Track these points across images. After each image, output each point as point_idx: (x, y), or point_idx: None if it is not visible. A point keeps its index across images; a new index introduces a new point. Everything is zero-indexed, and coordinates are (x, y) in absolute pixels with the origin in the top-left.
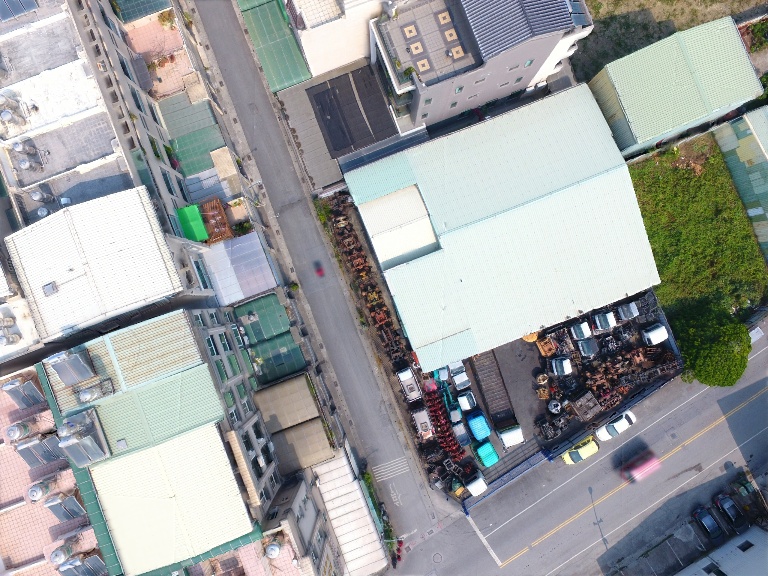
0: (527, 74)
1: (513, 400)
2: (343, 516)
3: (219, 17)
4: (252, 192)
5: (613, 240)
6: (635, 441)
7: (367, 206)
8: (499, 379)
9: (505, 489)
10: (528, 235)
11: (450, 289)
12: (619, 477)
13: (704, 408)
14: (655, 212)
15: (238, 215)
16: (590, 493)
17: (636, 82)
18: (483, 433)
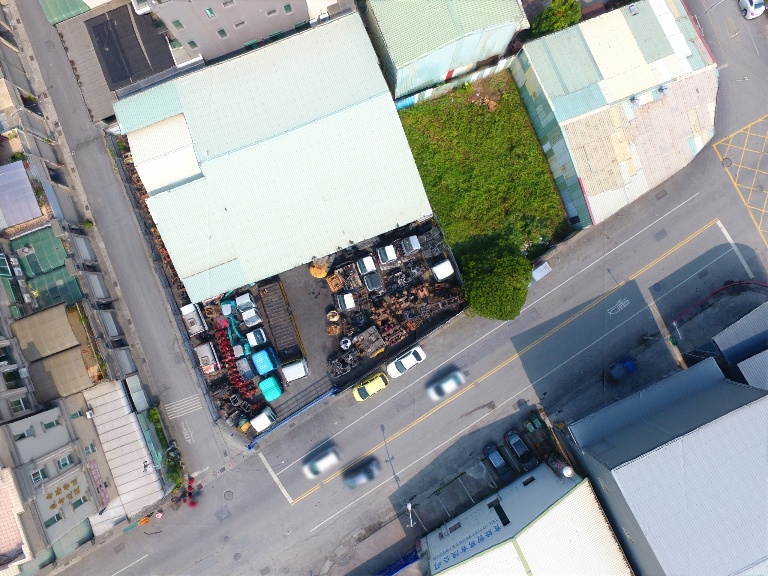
0: (292, 1)
1: (306, 338)
2: (118, 448)
3: None
4: (47, 130)
5: (381, 169)
6: (428, 379)
7: (136, 136)
8: (287, 315)
9: (298, 427)
10: (294, 164)
11: (215, 218)
12: (411, 415)
13: (497, 345)
14: (449, 149)
15: (16, 148)
16: (382, 430)
17: (393, 6)
18: (265, 367)
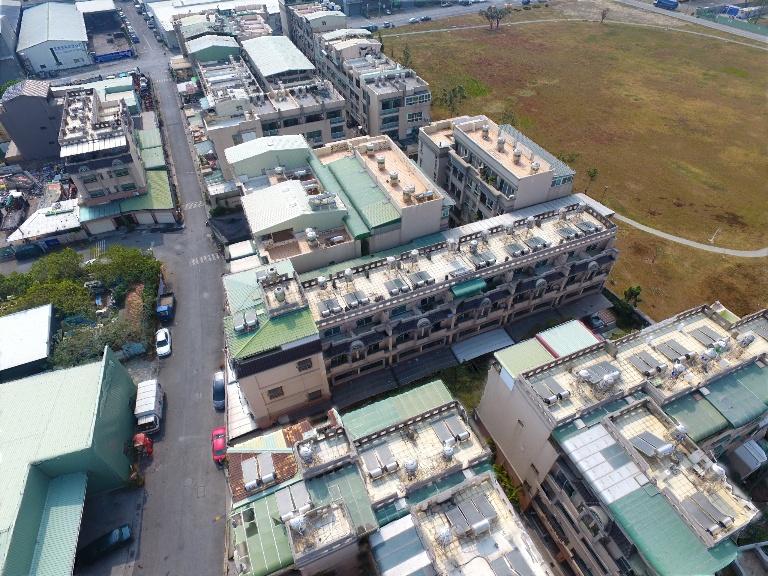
0: None
1: None
2: None
3: None
4: None
5: None
6: None
7: None
8: None
9: None
10: None
11: None
12: None
13: None
14: None
15: None
16: None
17: None
18: None
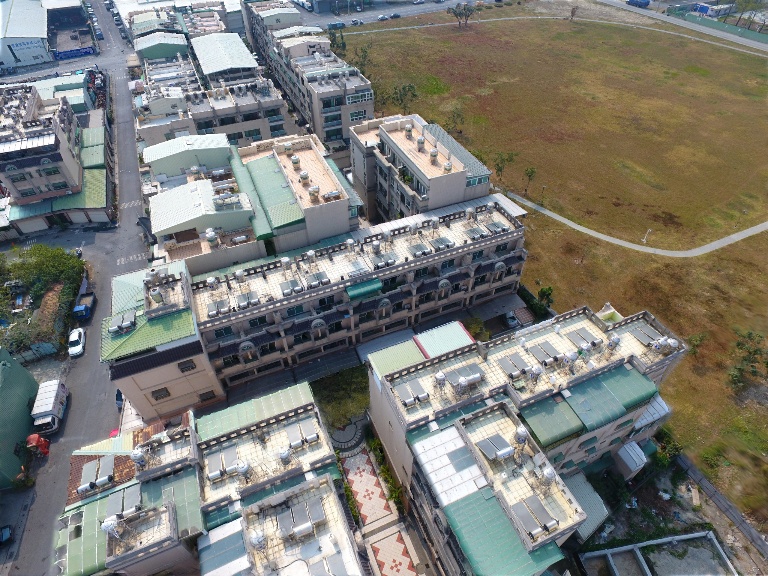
0: None
1: None
2: None
3: (128, 167)
4: None
5: None
6: None
7: None
8: None
9: None
10: None
11: None
12: None
13: None
14: None
15: None
16: None
17: None
18: None
